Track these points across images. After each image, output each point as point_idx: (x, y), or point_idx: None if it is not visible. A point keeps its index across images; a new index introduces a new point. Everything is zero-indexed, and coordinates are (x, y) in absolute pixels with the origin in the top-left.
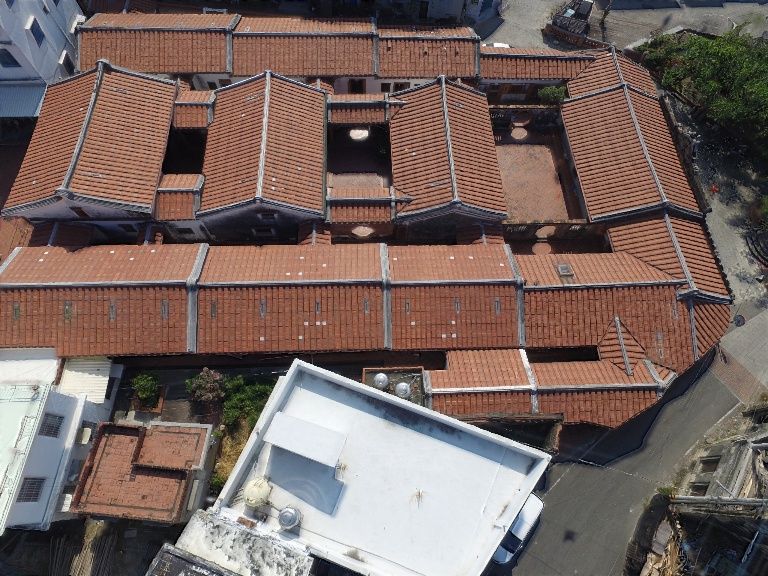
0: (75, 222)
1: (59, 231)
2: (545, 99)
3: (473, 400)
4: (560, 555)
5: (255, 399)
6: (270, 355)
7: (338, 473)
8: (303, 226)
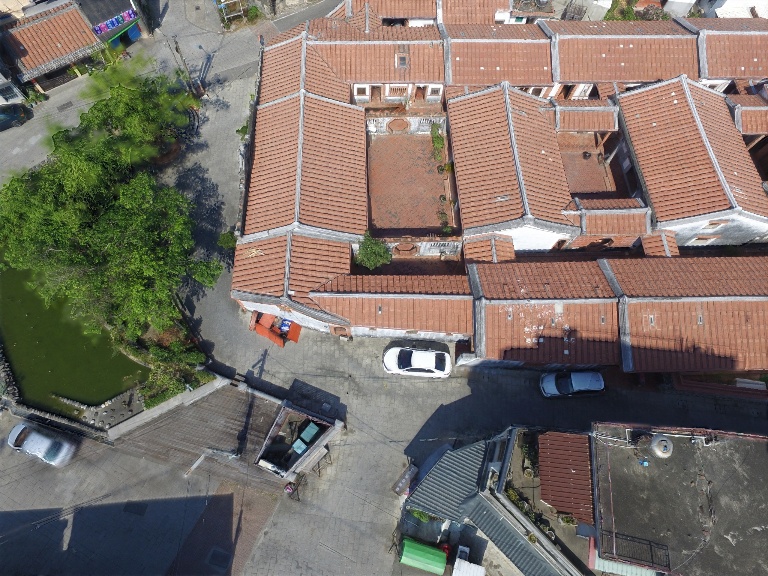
0: None
1: None
2: None
3: None
4: None
5: None
6: None
7: None
8: None
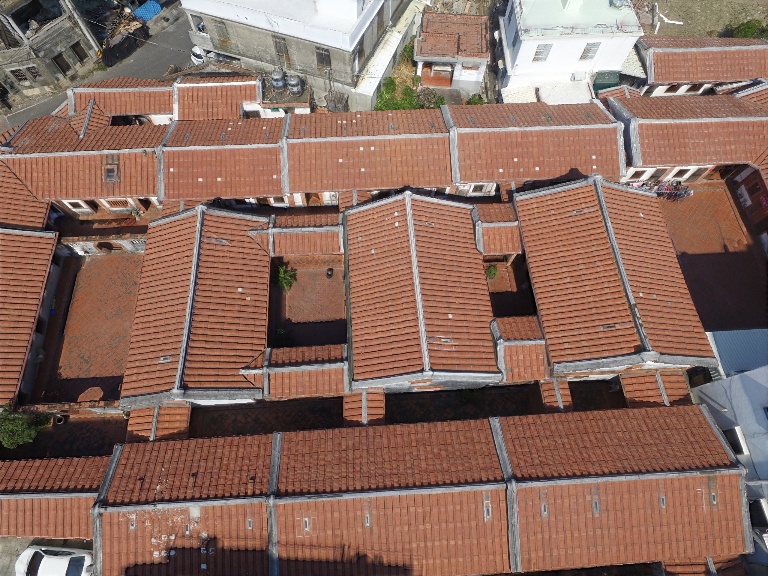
0: None
1: None
2: (30, 424)
3: (225, 81)
4: (189, 42)
5: None
6: None
7: None
8: None
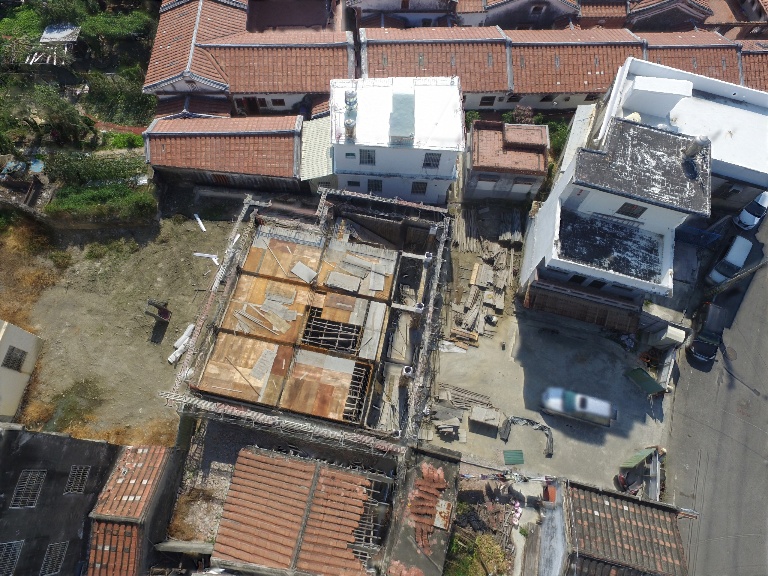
0: (394, 15)
1: (385, 20)
2: None
3: None
4: None
5: (550, 132)
6: (544, 113)
7: (672, 123)
8: (559, 21)
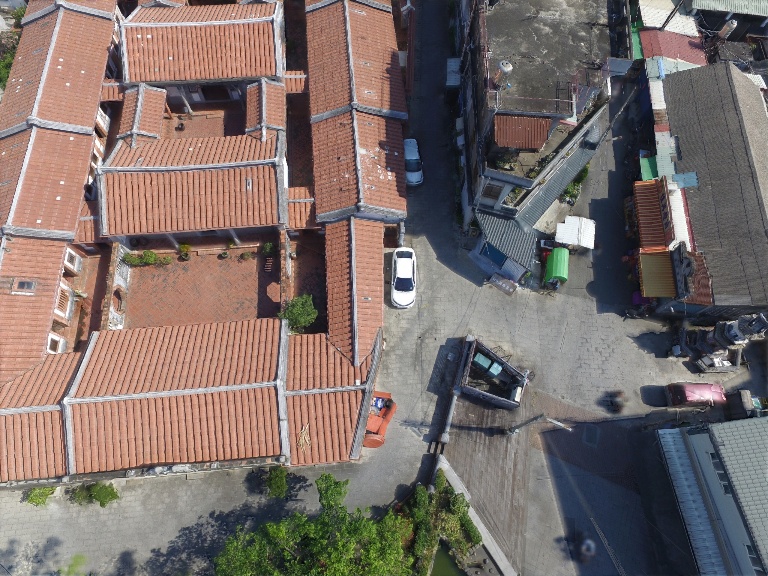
0: None
1: None
2: None
3: None
4: None
5: None
6: None
7: None
8: None
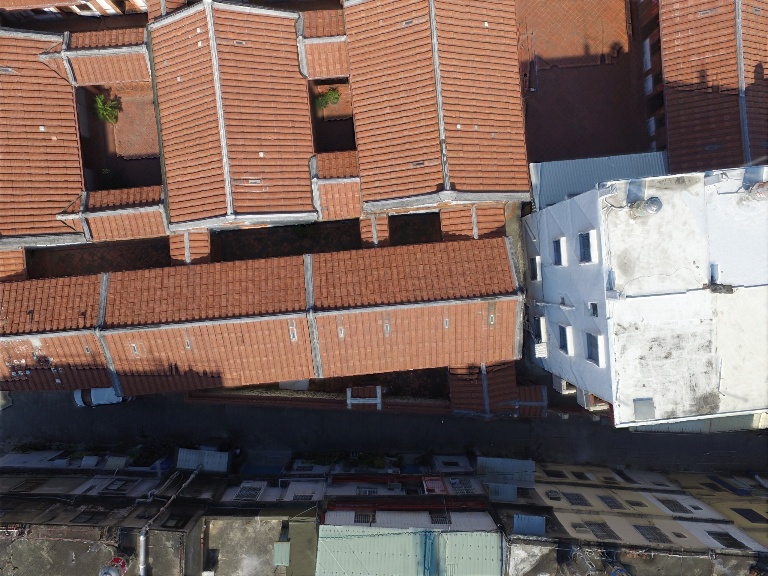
0: None
1: None
2: None
3: None
4: None
5: None
6: None
7: None
8: None
